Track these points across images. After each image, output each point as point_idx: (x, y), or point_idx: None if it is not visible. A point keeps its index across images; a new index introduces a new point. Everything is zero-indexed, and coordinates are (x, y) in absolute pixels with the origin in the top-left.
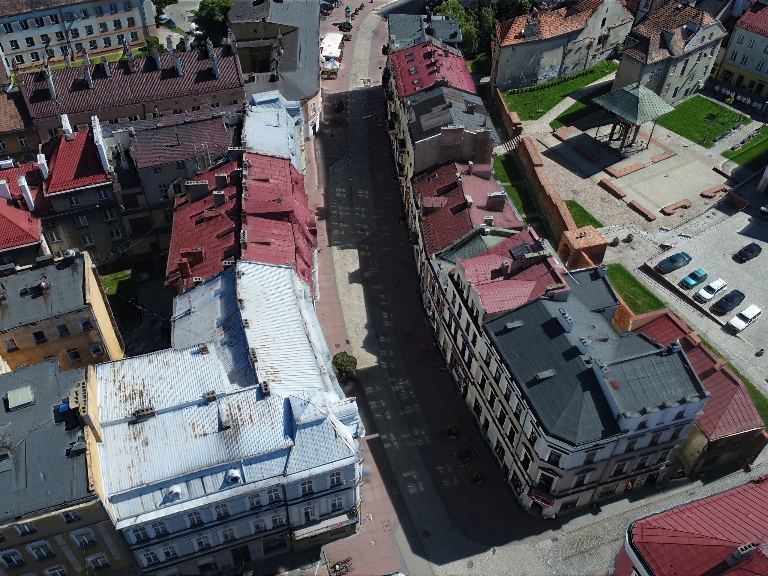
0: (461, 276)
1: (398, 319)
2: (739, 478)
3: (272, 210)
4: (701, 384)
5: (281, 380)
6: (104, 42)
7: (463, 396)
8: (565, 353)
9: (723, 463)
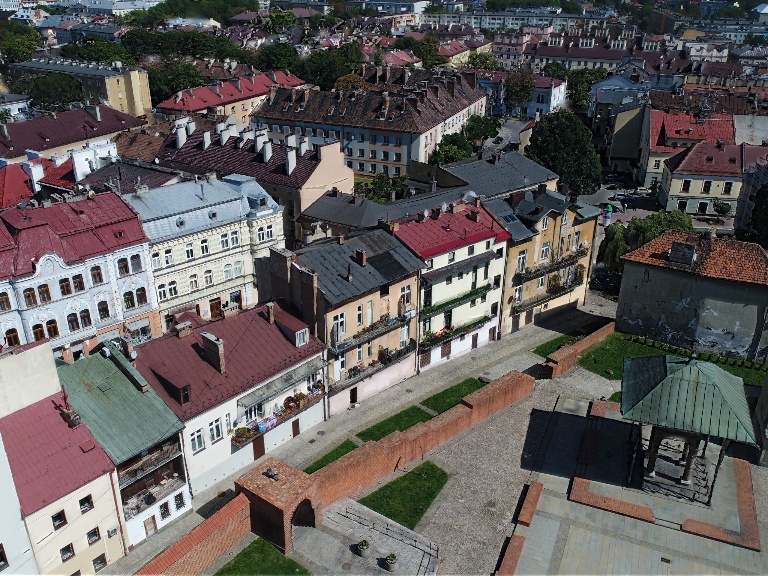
0: None
1: None
2: None
3: (12, 222)
4: None
5: None
6: (372, 168)
7: None
8: None
9: None
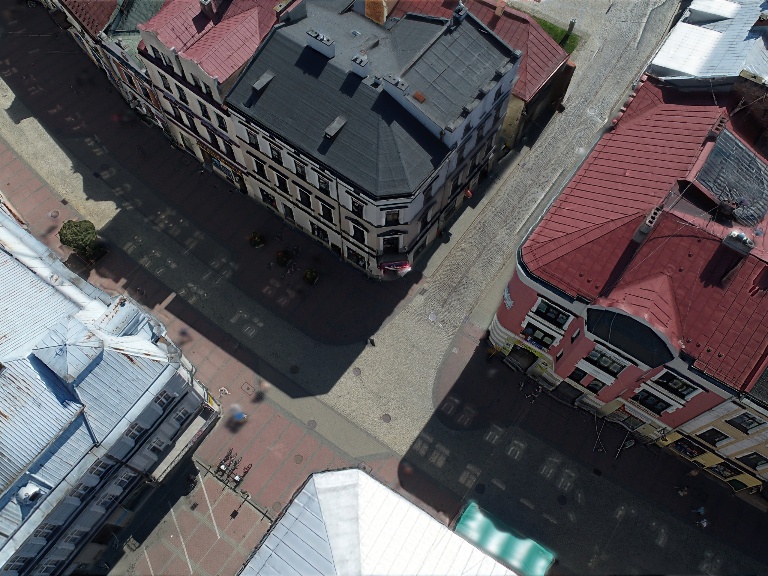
0: (157, 48)
1: (109, 139)
2: (558, 122)
3: None
4: (506, 45)
5: (5, 335)
6: None
7: (242, 192)
8: (343, 87)
9: (538, 115)
